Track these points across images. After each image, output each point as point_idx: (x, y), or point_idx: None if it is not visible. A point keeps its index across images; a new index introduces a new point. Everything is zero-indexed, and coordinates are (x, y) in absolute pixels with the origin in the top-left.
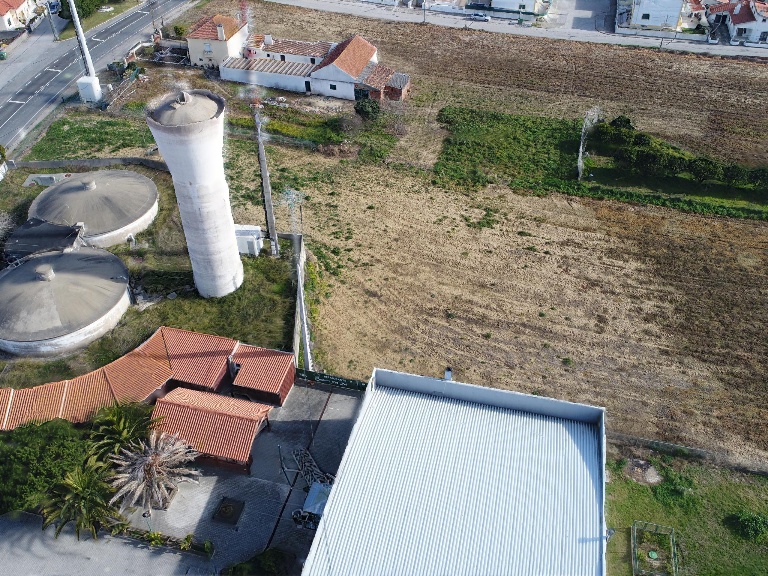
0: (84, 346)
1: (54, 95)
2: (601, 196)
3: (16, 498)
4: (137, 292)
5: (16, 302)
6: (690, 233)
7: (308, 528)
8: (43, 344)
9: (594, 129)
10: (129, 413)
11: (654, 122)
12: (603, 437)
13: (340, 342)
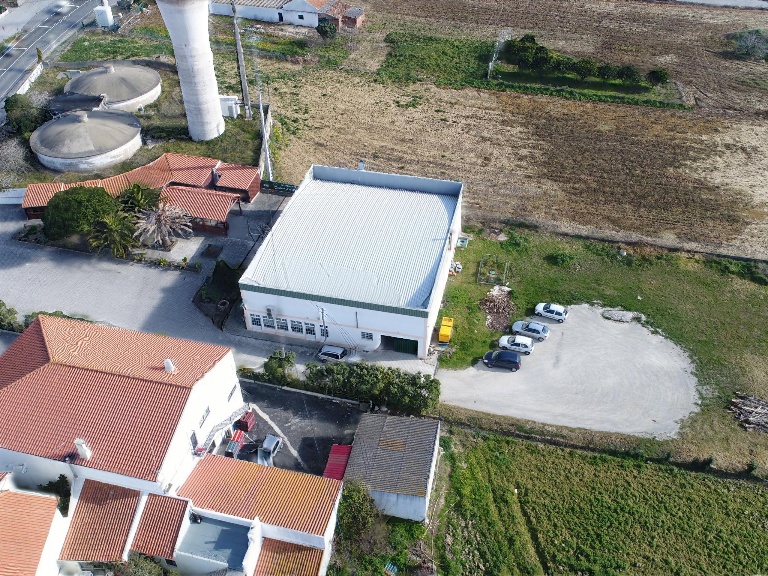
0: (110, 167)
1: (75, 23)
2: (504, 89)
3: (74, 222)
4: (147, 139)
5: (62, 135)
6: (567, 111)
7: None
8: (82, 162)
9: (505, 43)
10: (145, 191)
11: (558, 43)
12: (460, 195)
13: (295, 171)
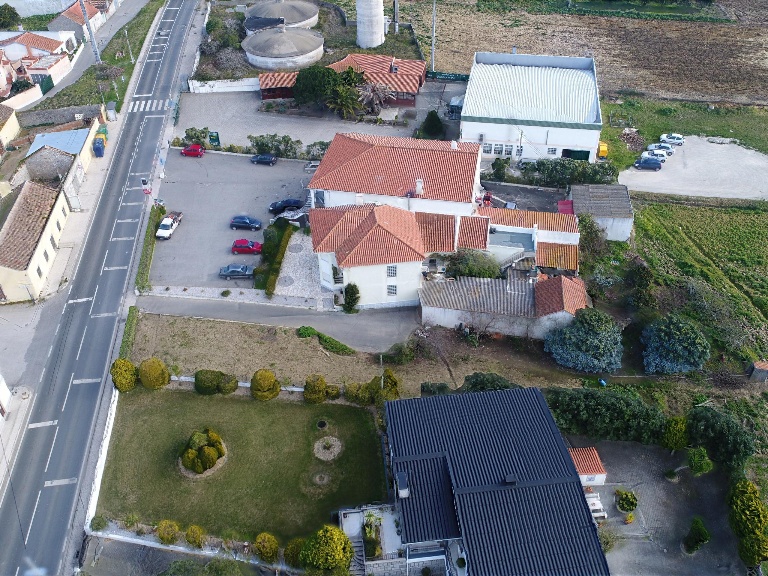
0: (307, 66)
1: None
2: (584, 13)
3: (322, 87)
4: None
5: (270, 41)
6: (638, 26)
7: (451, 119)
8: (289, 61)
9: None
10: None
11: None
12: (594, 65)
13: (444, 68)
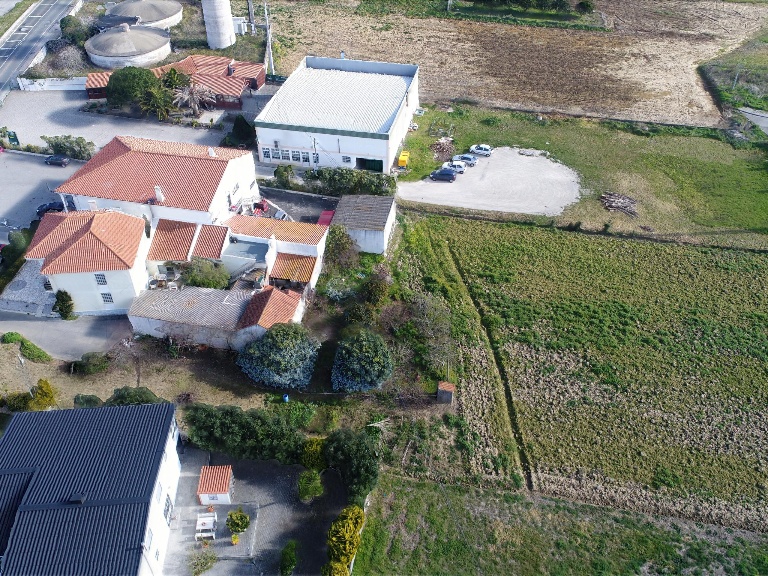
0: (148, 66)
1: None
2: (461, 18)
3: (131, 88)
4: None
5: (110, 40)
6: (510, 33)
7: None
8: (127, 60)
9: None
10: (179, 75)
11: None
12: (416, 73)
13: (291, 71)
